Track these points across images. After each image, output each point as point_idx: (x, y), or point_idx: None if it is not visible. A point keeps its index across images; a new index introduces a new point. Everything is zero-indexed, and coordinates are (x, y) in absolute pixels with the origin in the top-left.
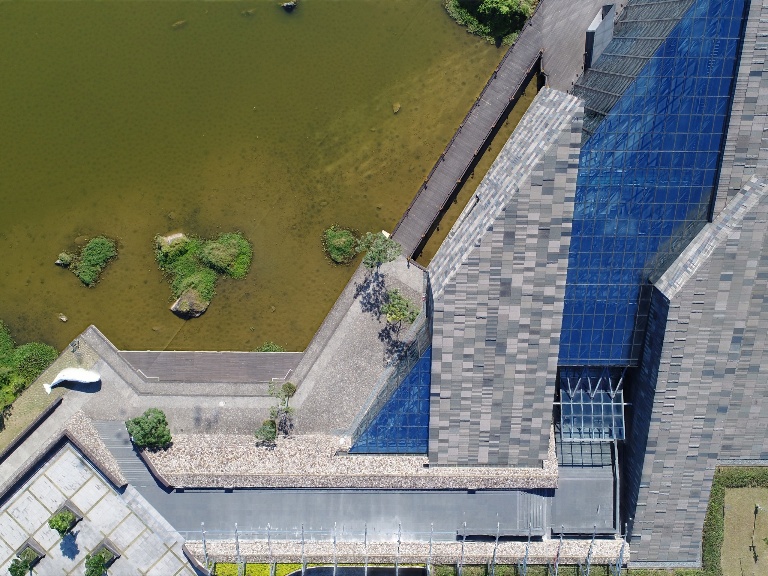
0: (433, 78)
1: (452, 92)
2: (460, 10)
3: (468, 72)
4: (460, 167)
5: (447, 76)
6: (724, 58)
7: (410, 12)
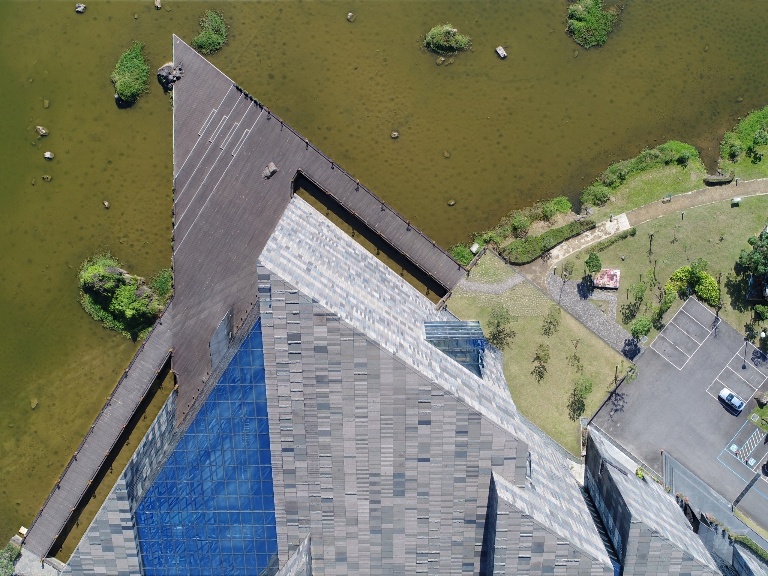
0: (70, 373)
1: (89, 387)
2: (94, 306)
3: (105, 367)
4: (93, 466)
5: (84, 371)
6: (257, 434)
7: (46, 307)
